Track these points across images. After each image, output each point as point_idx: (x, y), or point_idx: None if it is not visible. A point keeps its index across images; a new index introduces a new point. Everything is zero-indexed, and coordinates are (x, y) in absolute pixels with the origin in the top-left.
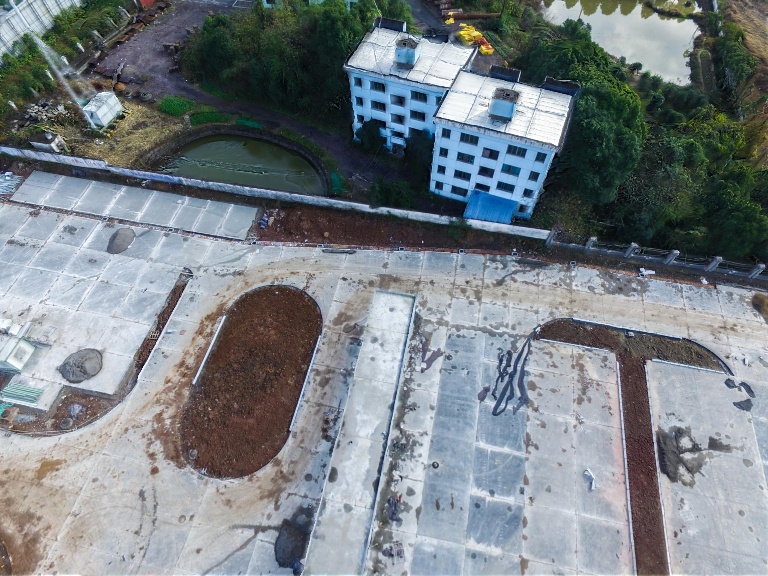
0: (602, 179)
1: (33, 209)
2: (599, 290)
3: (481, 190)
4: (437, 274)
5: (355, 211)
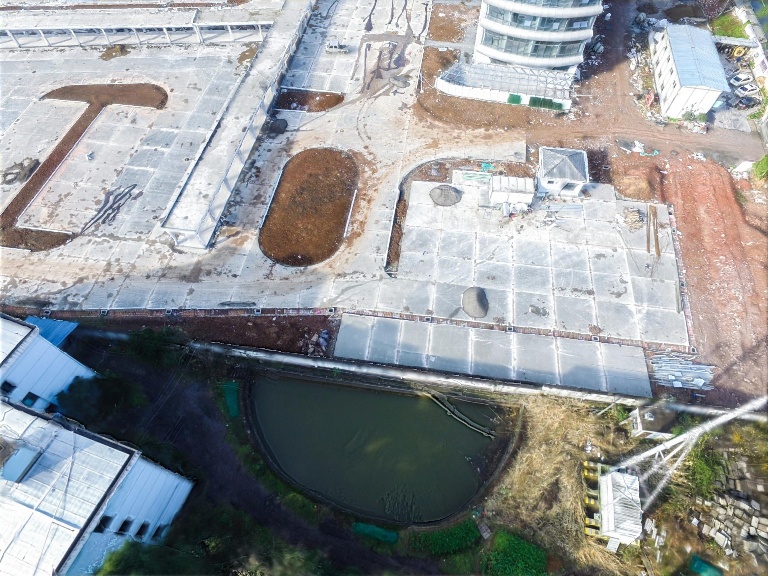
0: None
1: (602, 335)
2: None
3: None
4: (140, 284)
5: None
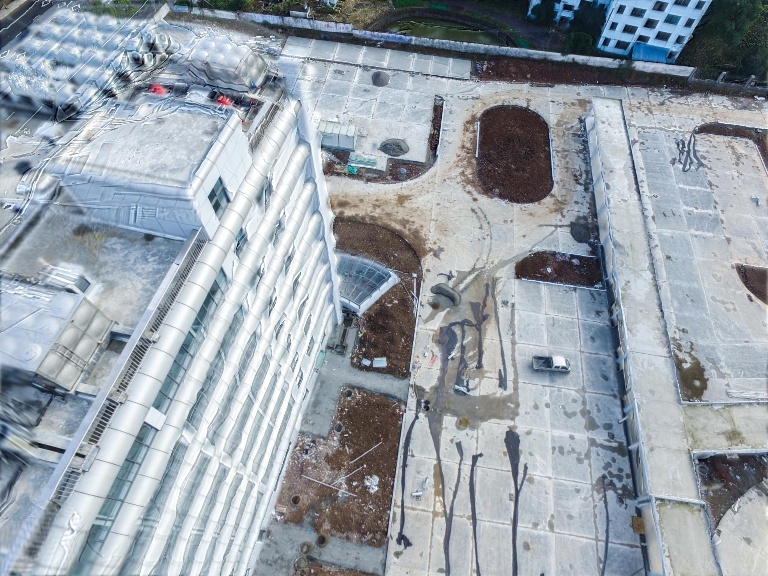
0: (736, 25)
1: (303, 60)
2: (731, 107)
3: (641, 41)
4: None
5: (547, 60)
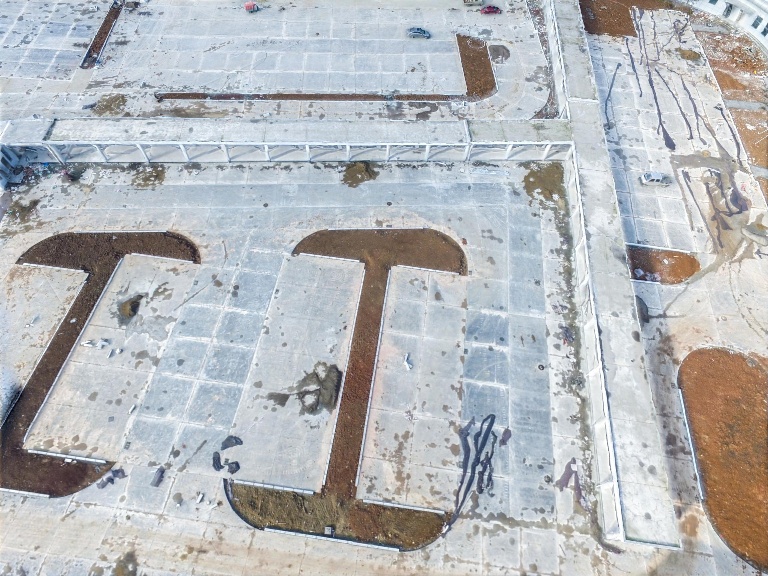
0: None
1: None
2: None
3: None
4: None
5: None
